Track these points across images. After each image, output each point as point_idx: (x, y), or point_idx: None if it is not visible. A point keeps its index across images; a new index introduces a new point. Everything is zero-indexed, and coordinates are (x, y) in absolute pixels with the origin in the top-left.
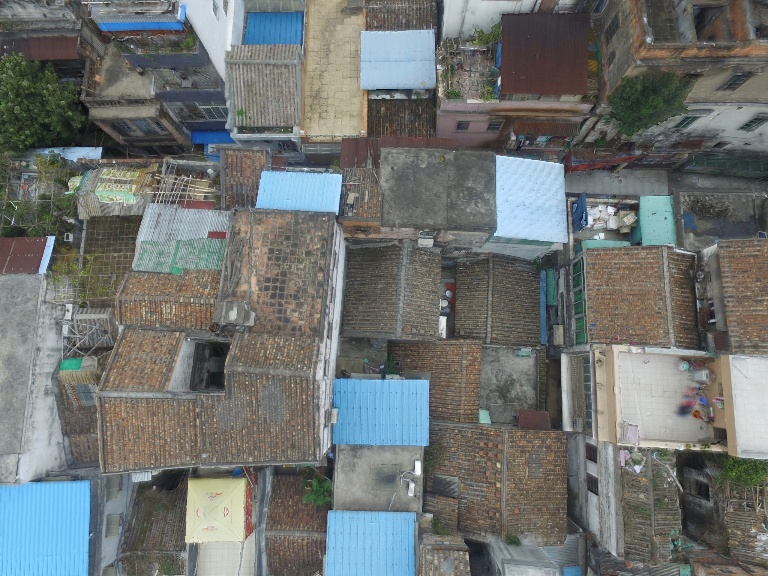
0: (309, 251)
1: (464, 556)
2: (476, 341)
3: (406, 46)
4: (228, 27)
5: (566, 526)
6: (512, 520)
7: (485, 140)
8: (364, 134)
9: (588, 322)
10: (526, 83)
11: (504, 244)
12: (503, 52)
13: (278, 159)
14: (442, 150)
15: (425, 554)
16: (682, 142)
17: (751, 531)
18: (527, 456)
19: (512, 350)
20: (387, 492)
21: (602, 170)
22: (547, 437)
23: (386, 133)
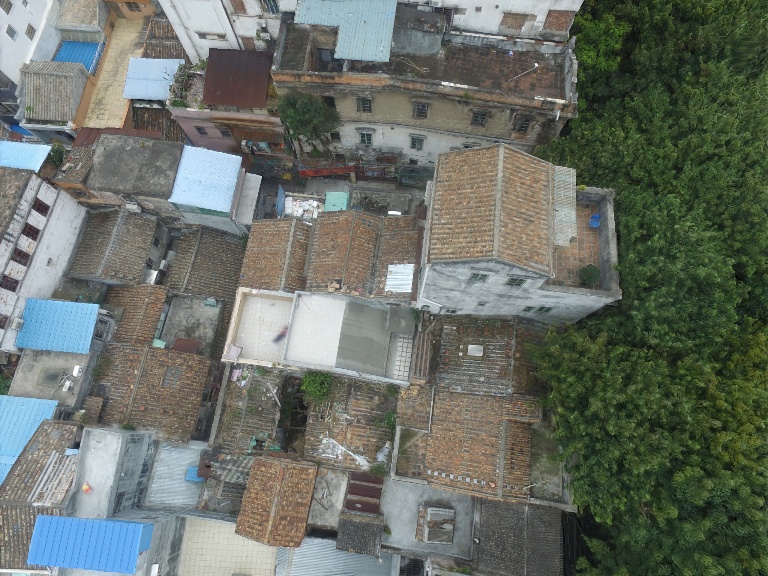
0: (5, 195)
1: (72, 429)
2: (162, 286)
3: (162, 70)
4: (31, 47)
5: (192, 430)
6: (137, 415)
7: (230, 145)
8: None
9: (240, 274)
10: (220, 97)
11: (195, 214)
12: (206, 74)
13: (15, 134)
14: (145, 138)
15: (44, 425)
16: (380, 157)
17: (319, 437)
18: (164, 369)
19: (203, 300)
20: (51, 389)
21: (344, 180)
22: (190, 359)
23: None
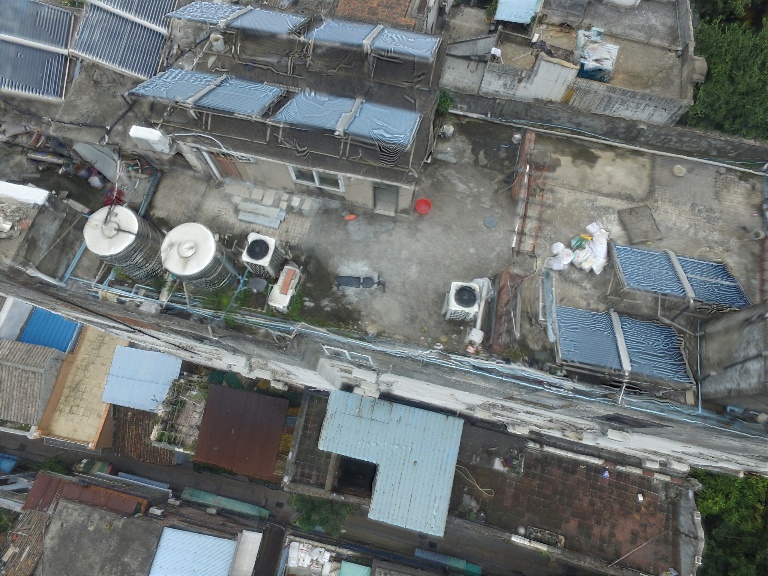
0: None
1: None
2: None
3: (154, 367)
4: None
5: None
6: None
7: None
8: (92, 447)
9: None
10: (218, 454)
11: None
12: (203, 420)
13: None
14: (114, 514)
15: None
16: None
17: None
18: None
19: None
20: None
21: None
22: None
23: (131, 434)
